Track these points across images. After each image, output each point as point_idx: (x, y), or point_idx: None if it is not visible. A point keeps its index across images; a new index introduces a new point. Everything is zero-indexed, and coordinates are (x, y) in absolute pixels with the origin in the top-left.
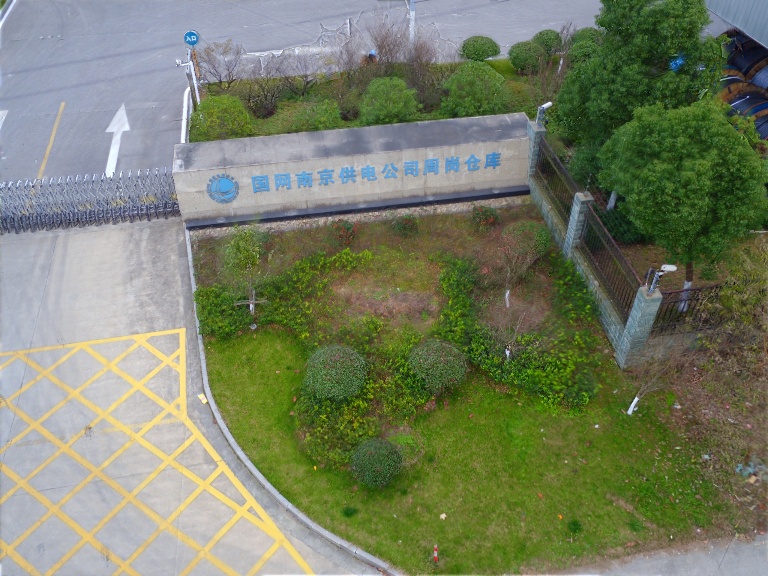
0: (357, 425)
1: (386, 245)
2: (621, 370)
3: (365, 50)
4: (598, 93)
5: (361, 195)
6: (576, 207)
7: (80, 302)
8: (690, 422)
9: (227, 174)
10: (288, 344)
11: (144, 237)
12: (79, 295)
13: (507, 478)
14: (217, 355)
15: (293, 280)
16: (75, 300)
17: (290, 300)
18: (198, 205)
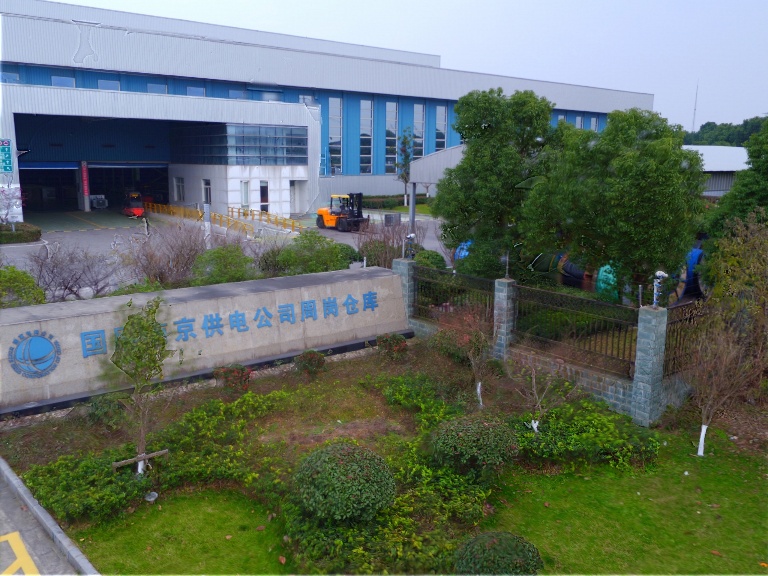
0: (419, 544)
1: (291, 390)
2: (648, 428)
3: (168, 249)
4: (483, 181)
5: (231, 353)
6: (501, 294)
7: None
8: (761, 444)
9: (42, 330)
10: (223, 503)
11: None
12: None
13: (659, 549)
14: (103, 544)
15: (191, 430)
16: None
17: (200, 450)
18: None
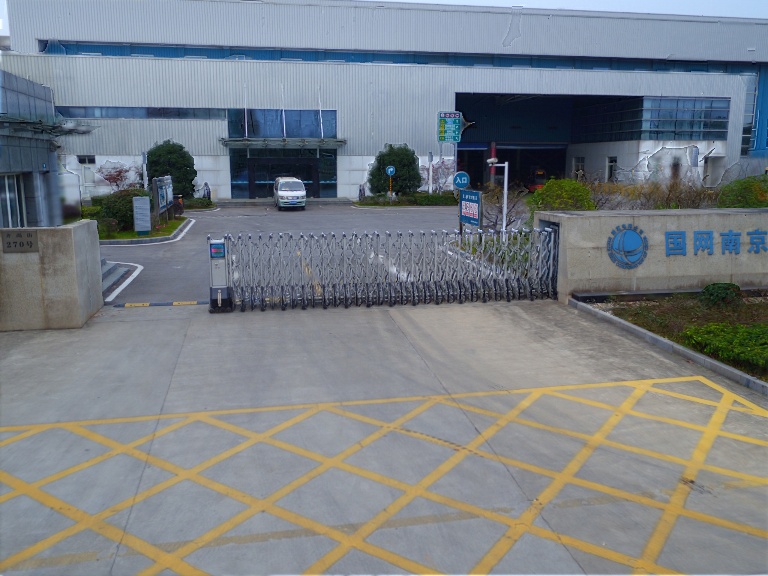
0: None
1: None
2: None
3: (667, 188)
4: None
5: None
6: None
7: (486, 355)
8: None
9: (635, 225)
10: None
11: (518, 310)
12: (476, 349)
13: None
14: None
15: None
16: (475, 353)
17: None
18: (592, 269)
